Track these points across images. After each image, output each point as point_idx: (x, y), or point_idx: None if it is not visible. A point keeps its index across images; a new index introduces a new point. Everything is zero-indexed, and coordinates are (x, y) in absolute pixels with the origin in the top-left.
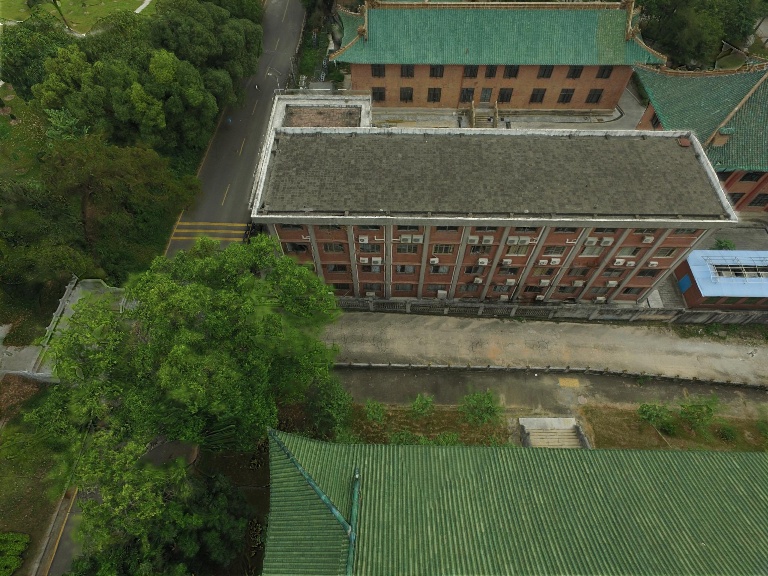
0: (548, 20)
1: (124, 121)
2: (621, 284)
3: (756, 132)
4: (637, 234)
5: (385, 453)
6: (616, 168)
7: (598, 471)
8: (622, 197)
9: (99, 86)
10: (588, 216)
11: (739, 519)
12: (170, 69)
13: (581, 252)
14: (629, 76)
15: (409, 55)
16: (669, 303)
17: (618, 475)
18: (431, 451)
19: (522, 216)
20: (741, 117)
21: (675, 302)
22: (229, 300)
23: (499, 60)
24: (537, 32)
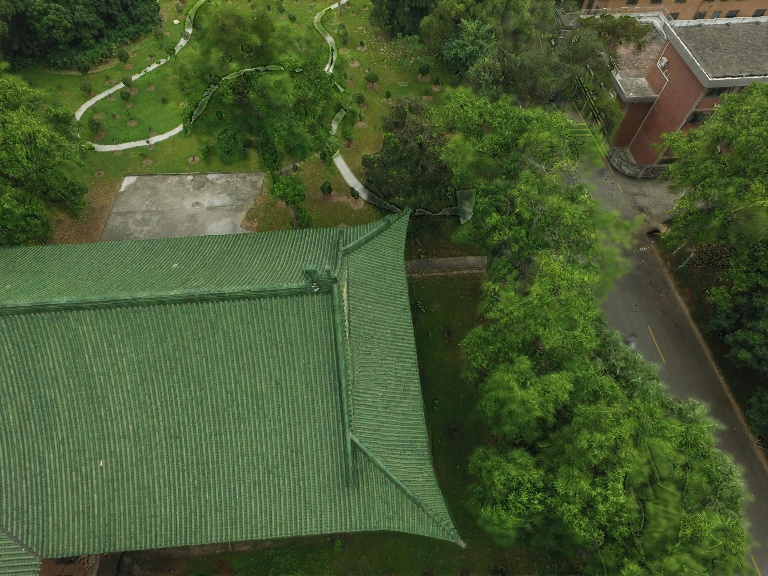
0: None
1: (511, 30)
2: None
3: None
4: None
5: None
6: None
7: None
8: None
9: None
10: None
11: None
12: None
13: None
14: None
15: None
16: None
17: None
18: None
19: None
20: None
21: None
22: None
23: None
24: None
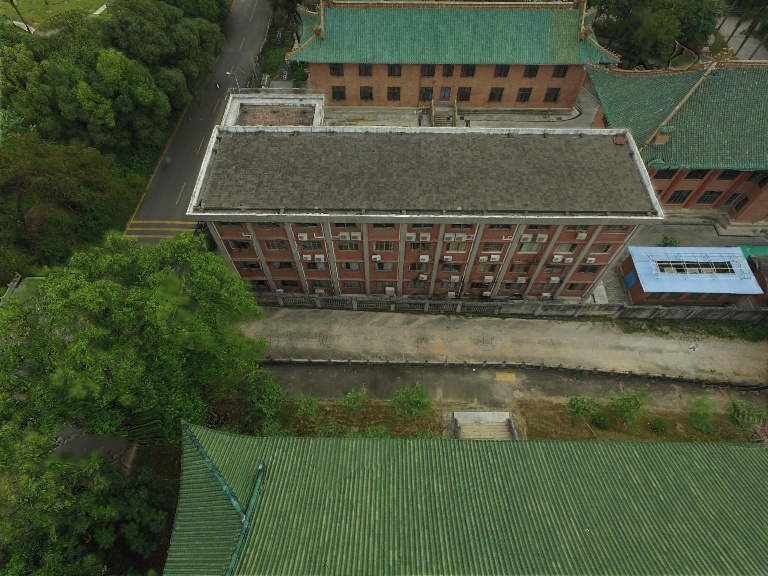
0: (502, 20)
1: (71, 120)
2: (564, 280)
3: (697, 130)
4: (571, 231)
5: (296, 445)
6: (551, 166)
7: (501, 461)
8: (554, 194)
9: (44, 85)
10: (519, 213)
11: (628, 506)
12: (118, 68)
13: (519, 249)
14: (584, 75)
15: (365, 54)
16: (615, 299)
17: (520, 465)
18: (341, 443)
19: (455, 213)
20: (682, 116)
21: (621, 298)
22: (135, 296)
23: (454, 59)
24: (492, 32)
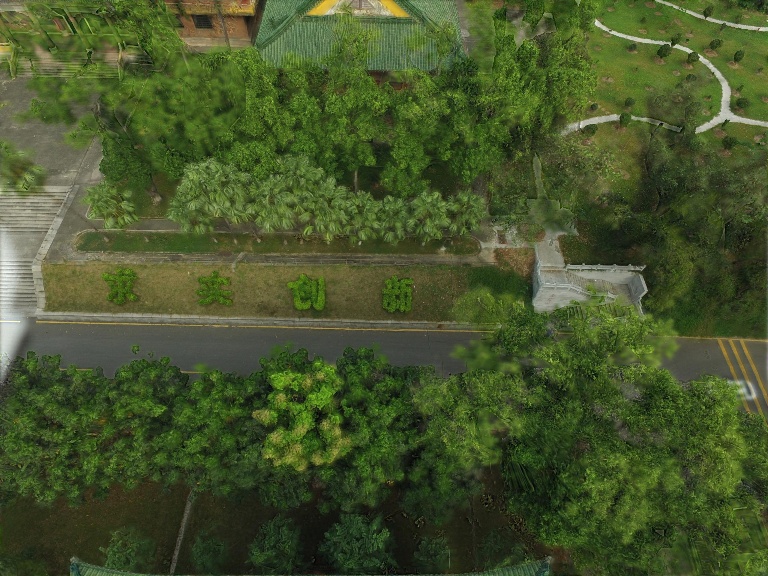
0: None
1: None
2: None
3: None
4: None
5: None
6: None
7: None
8: None
9: None
10: None
11: None
12: None
13: None
14: None
15: None
16: None
17: None
18: None
19: None
20: None
21: None
22: None
23: None
24: None
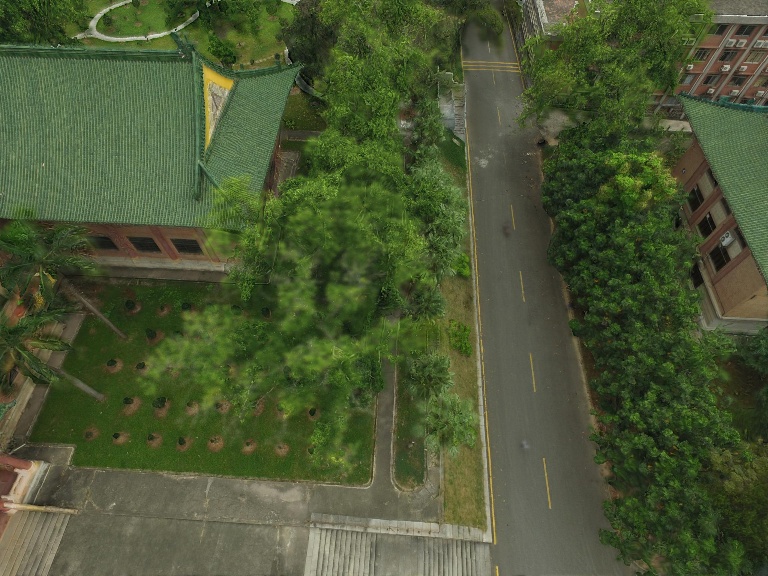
0: None
1: None
2: None
3: None
4: None
5: None
6: None
7: None
8: None
9: None
10: None
11: None
12: None
13: None
14: None
15: None
16: None
17: None
18: None
19: None
20: None
21: None
22: None
23: None
24: None
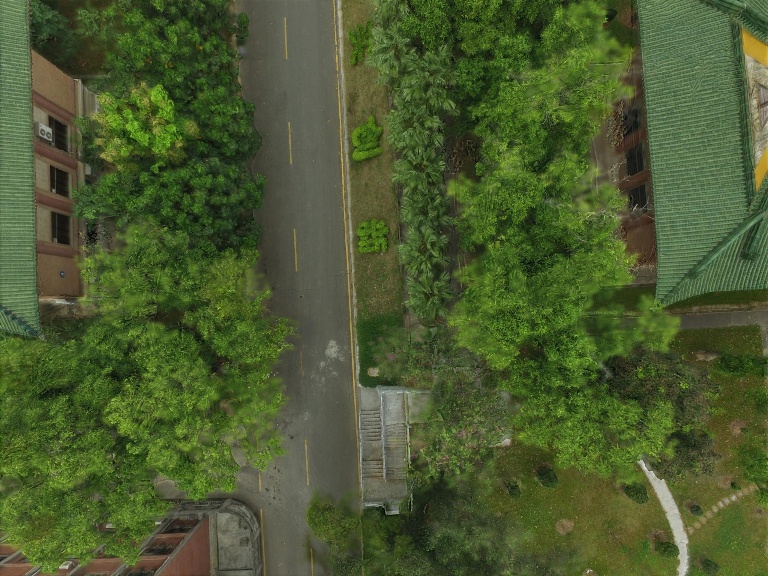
0: None
1: None
2: None
3: None
4: None
5: None
6: None
7: None
8: None
9: None
10: None
11: None
12: None
13: None
14: None
15: None
16: None
17: None
18: None
19: None
20: None
21: None
22: None
23: None
24: None
